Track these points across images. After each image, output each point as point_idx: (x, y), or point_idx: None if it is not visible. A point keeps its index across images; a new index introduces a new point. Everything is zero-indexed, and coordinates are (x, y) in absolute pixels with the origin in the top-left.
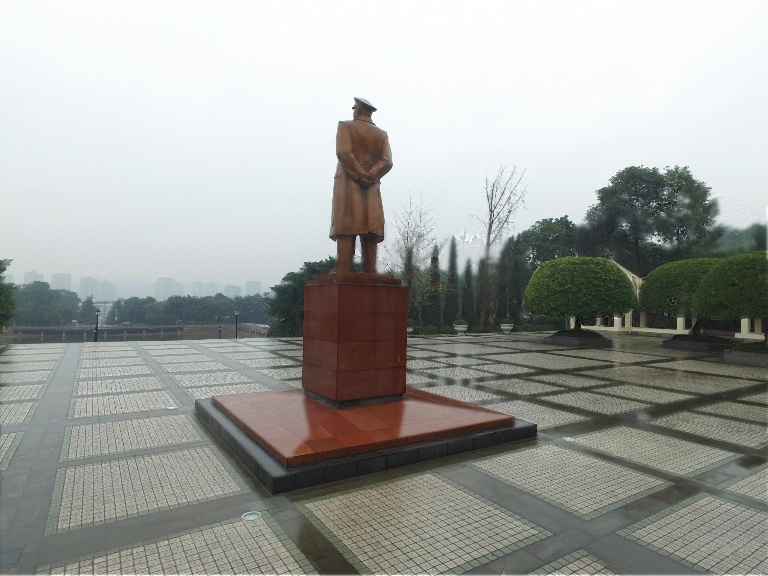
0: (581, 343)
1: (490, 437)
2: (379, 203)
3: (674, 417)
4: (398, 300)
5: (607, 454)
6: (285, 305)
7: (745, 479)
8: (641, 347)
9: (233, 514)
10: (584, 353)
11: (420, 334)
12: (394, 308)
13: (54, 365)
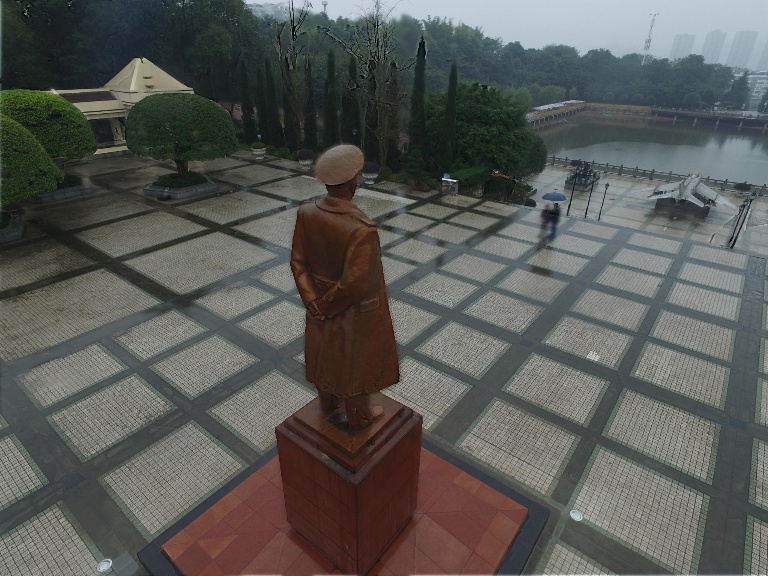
0: None
1: None
2: (342, 348)
3: None
4: (342, 490)
5: None
6: None
7: None
8: None
9: (109, 552)
10: None
11: None
12: (337, 494)
13: (435, 256)
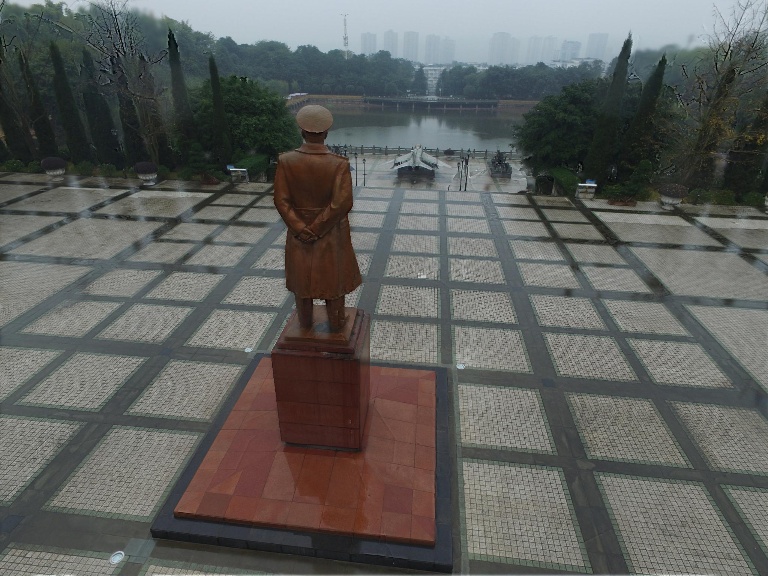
0: None
1: (375, 558)
2: (331, 259)
3: None
4: (345, 372)
5: None
6: (527, 143)
7: None
8: None
9: (113, 548)
10: None
11: (700, 203)
12: (340, 378)
13: (262, 236)
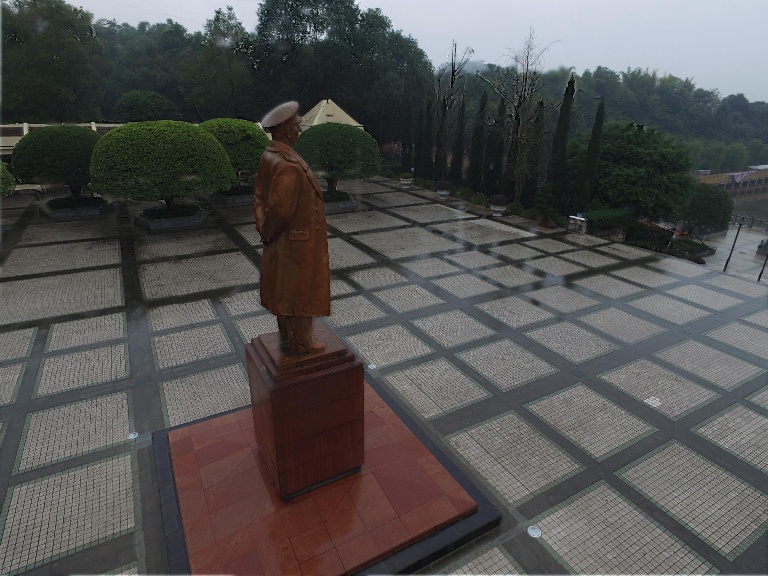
0: None
1: None
2: (276, 269)
3: None
4: None
5: None
6: None
7: None
8: None
9: (139, 429)
10: None
11: None
12: (266, 403)
13: (525, 283)
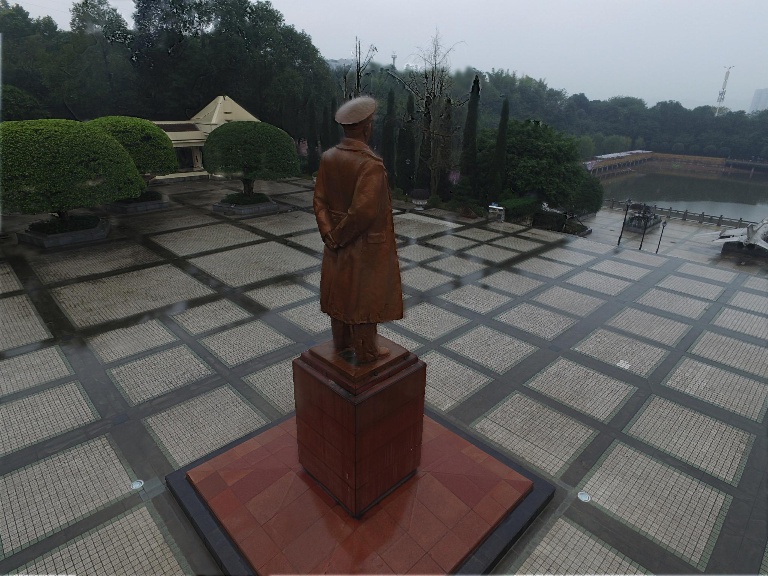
0: None
1: None
2: (350, 275)
3: None
4: (344, 412)
5: None
6: None
7: None
8: None
9: (142, 475)
10: None
11: None
12: (340, 418)
13: (473, 271)
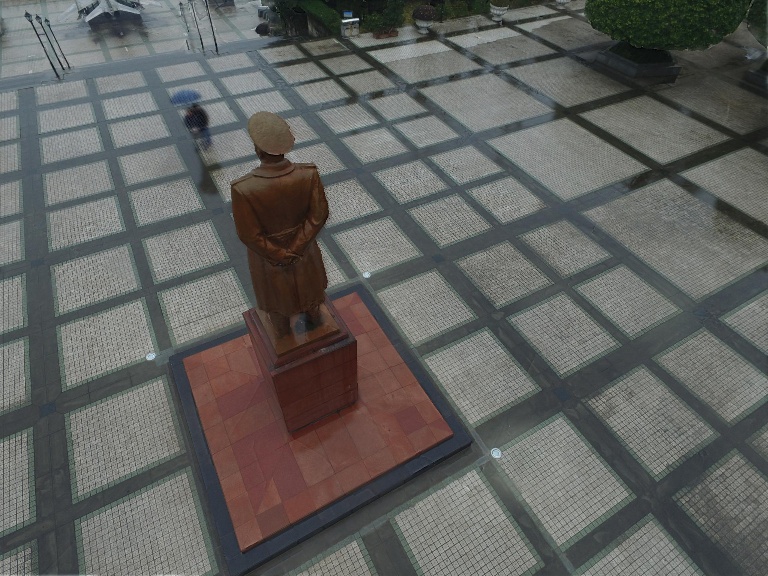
0: (639, 74)
1: None
2: (313, 269)
3: (623, 385)
4: (345, 354)
5: (516, 495)
6: None
7: (606, 556)
8: (713, 83)
9: None
10: (626, 119)
11: (444, 19)
12: (340, 361)
13: (19, 197)
